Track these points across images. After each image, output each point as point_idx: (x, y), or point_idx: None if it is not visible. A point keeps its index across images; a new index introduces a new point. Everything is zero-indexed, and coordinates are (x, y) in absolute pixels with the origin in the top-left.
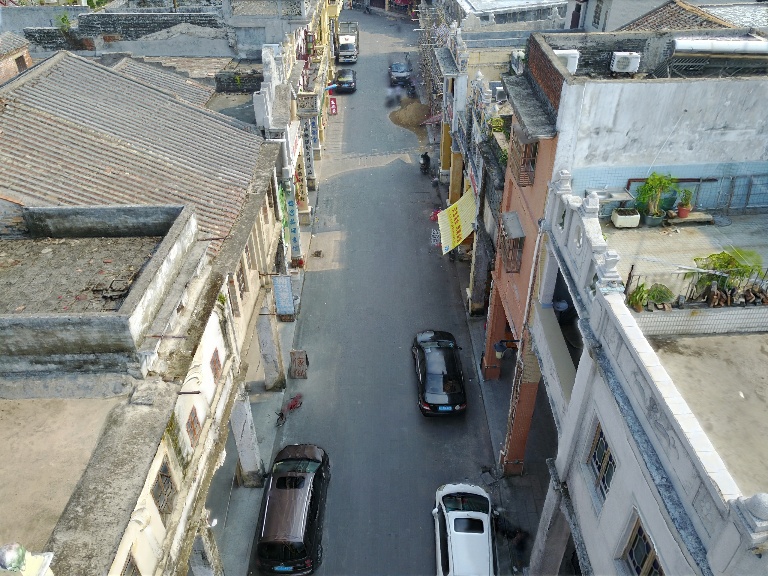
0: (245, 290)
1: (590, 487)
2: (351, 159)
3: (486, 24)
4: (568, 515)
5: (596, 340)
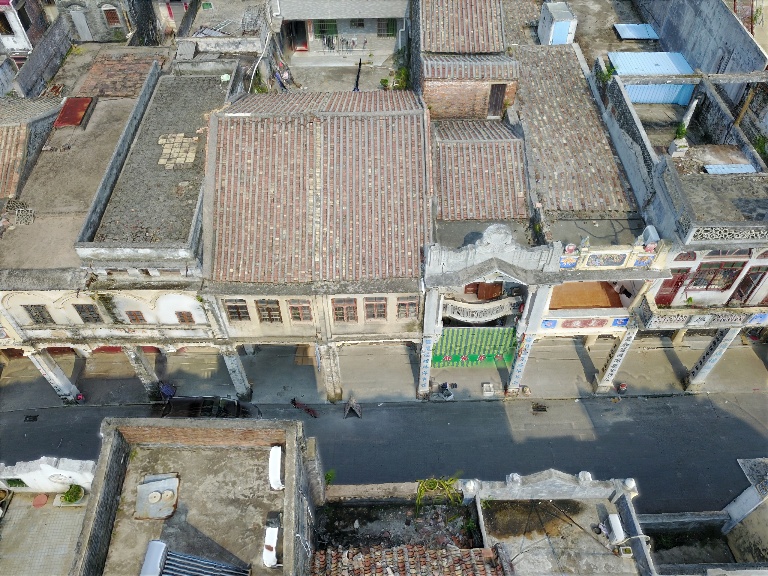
0: (282, 322)
1: None
2: None
3: None
4: None
5: None
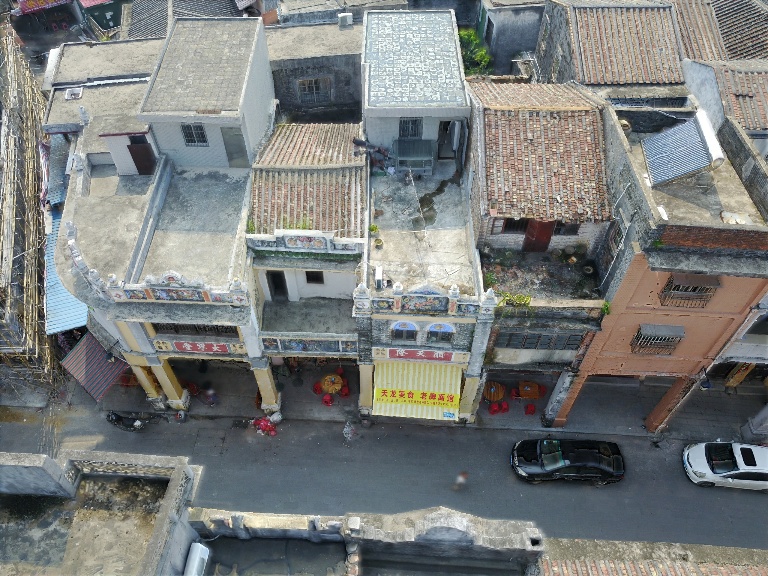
0: None
1: None
2: None
3: (73, 238)
4: None
5: None
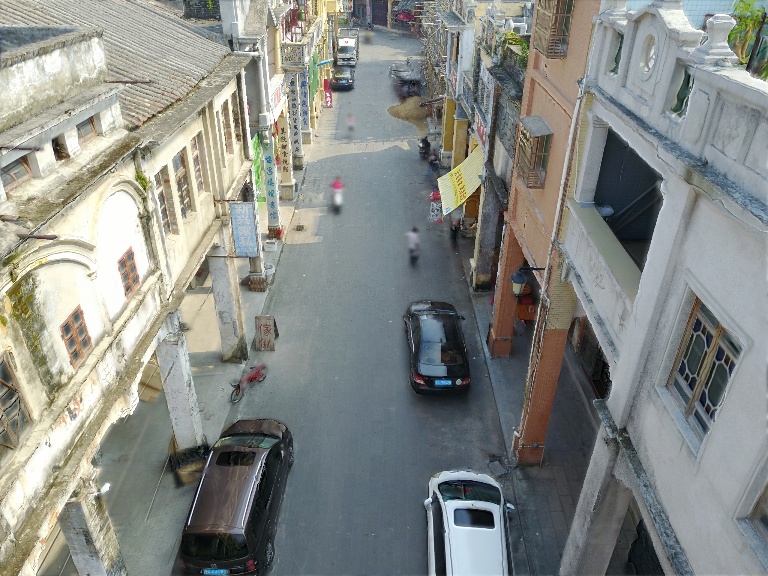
0: (191, 208)
1: (676, 416)
2: (344, 145)
3: None
4: (634, 473)
5: (695, 158)
